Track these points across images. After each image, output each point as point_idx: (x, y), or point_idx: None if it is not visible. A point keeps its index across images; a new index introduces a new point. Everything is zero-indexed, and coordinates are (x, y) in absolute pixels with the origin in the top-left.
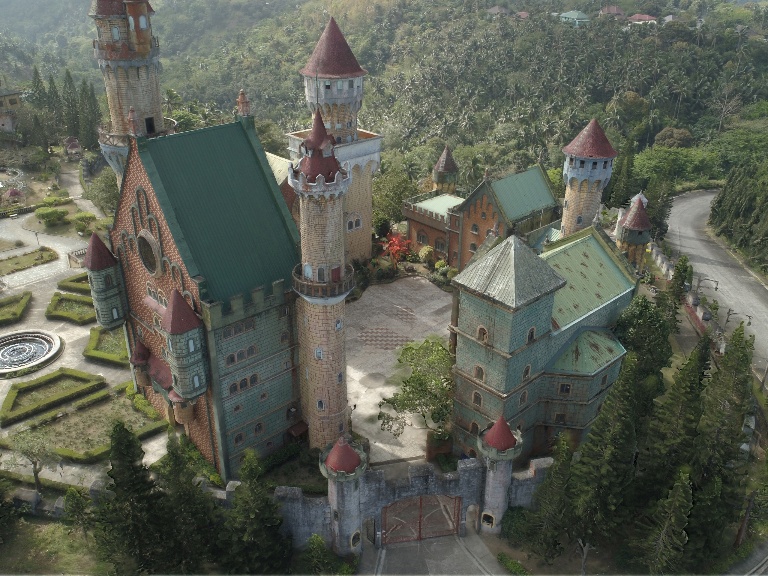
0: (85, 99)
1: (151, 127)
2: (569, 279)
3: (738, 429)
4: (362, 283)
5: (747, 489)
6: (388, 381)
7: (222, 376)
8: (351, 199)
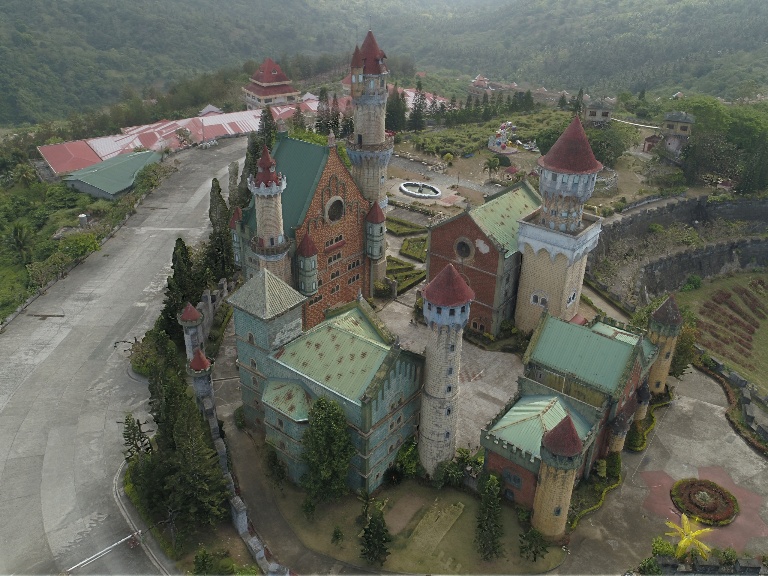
0: (759, 147)
1: (361, 140)
2: (328, 350)
3: (188, 465)
4: (510, 347)
5: (225, 560)
6: None
7: (246, 265)
8: (541, 277)
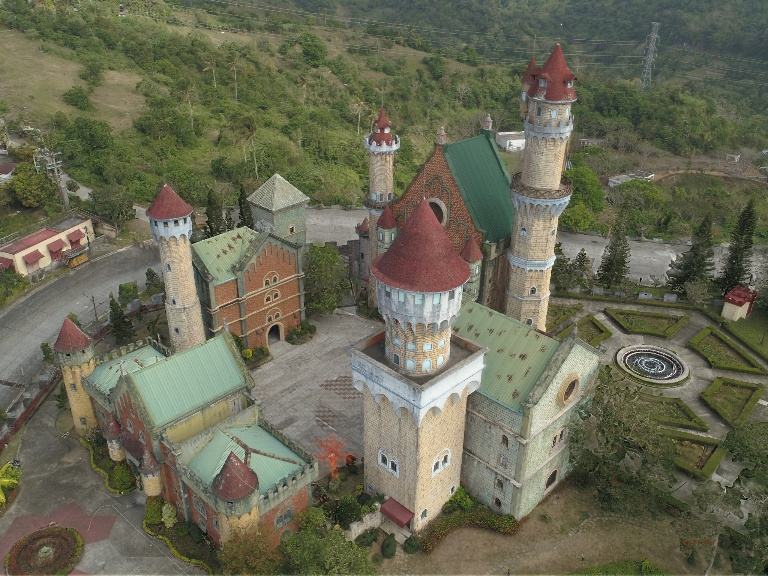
0: None
1: None
2: None
3: None
4: None
5: (157, 289)
6: (345, 350)
7: None
8: None
